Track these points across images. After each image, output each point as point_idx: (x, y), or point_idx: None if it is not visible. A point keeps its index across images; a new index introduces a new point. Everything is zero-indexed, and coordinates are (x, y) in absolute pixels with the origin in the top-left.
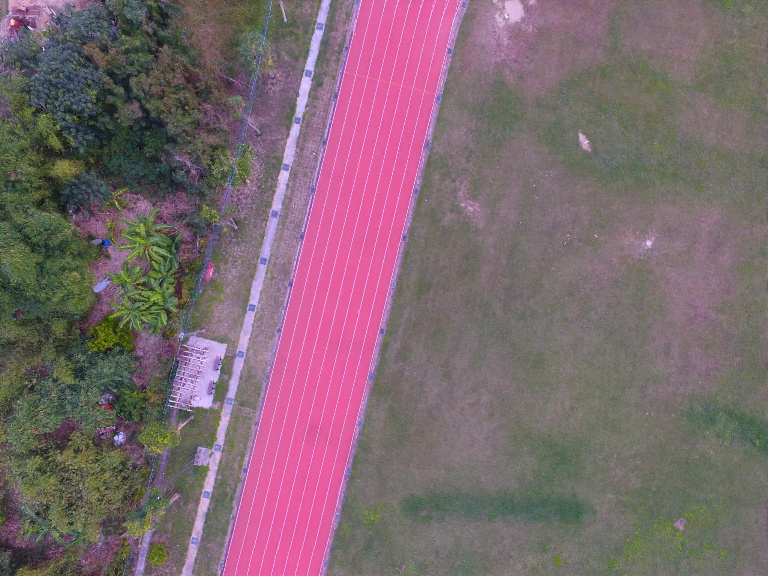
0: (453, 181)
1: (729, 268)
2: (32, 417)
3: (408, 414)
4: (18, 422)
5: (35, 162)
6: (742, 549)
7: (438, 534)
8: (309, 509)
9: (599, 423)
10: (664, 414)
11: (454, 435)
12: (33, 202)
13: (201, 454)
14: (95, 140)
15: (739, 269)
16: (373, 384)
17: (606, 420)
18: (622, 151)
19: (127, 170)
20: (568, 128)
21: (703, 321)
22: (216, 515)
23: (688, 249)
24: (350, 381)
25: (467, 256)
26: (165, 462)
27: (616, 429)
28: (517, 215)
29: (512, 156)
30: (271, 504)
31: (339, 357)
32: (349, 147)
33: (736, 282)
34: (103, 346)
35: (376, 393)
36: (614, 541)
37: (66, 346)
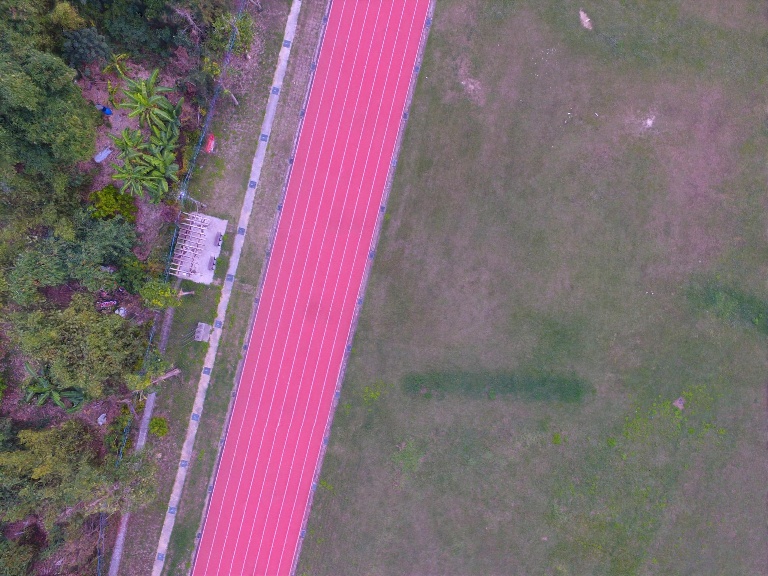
0: (454, 59)
1: (730, 147)
2: (33, 269)
3: (408, 292)
4: (19, 271)
5: (36, 5)
6: (741, 428)
7: (438, 412)
8: (309, 386)
9: (599, 302)
10: (664, 293)
11: (454, 313)
12: (34, 45)
13: (202, 329)
14: (96, 2)
15: (740, 148)
16: (373, 262)
17: (606, 299)
18: (623, 29)
19: (128, 35)
20: (569, 6)
21: (703, 200)
22: (216, 391)
23: (689, 128)
24: (350, 259)
25: (468, 134)
26: (166, 338)
27: (616, 308)
28: (518, 93)
29: (513, 34)
30: (271, 381)
31: (339, 235)
32: (350, 24)
33: (736, 161)
34: (104, 212)
35: (376, 271)
36: (613, 420)
37: (67, 213)
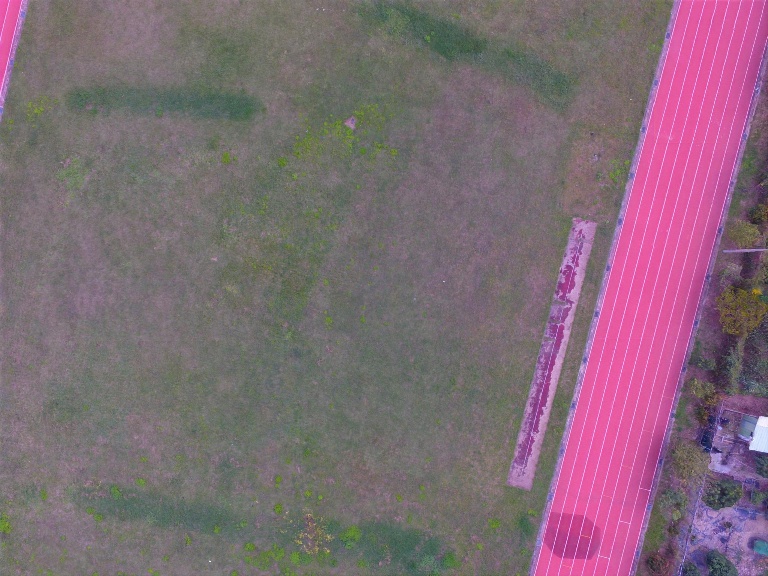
0: None
1: None
2: None
3: (72, 5)
4: None
5: None
6: (414, 149)
7: (104, 128)
8: None
9: (268, 18)
10: (335, 10)
11: (119, 27)
12: None
13: None
14: None
15: None
16: None
17: (276, 15)
18: None
19: None
20: None
21: None
22: None
23: None
24: None
25: None
26: None
27: (286, 24)
28: None
29: None
30: None
31: None
32: None
33: None
34: None
35: None
36: (284, 138)
37: None
